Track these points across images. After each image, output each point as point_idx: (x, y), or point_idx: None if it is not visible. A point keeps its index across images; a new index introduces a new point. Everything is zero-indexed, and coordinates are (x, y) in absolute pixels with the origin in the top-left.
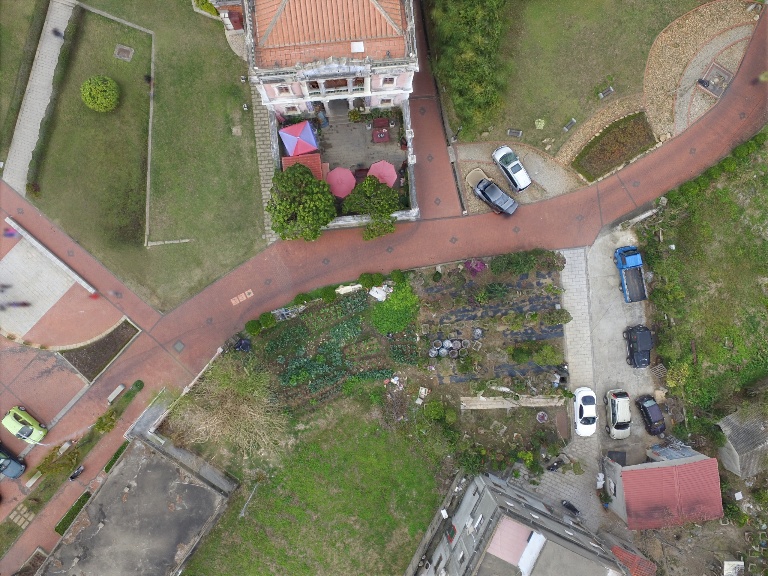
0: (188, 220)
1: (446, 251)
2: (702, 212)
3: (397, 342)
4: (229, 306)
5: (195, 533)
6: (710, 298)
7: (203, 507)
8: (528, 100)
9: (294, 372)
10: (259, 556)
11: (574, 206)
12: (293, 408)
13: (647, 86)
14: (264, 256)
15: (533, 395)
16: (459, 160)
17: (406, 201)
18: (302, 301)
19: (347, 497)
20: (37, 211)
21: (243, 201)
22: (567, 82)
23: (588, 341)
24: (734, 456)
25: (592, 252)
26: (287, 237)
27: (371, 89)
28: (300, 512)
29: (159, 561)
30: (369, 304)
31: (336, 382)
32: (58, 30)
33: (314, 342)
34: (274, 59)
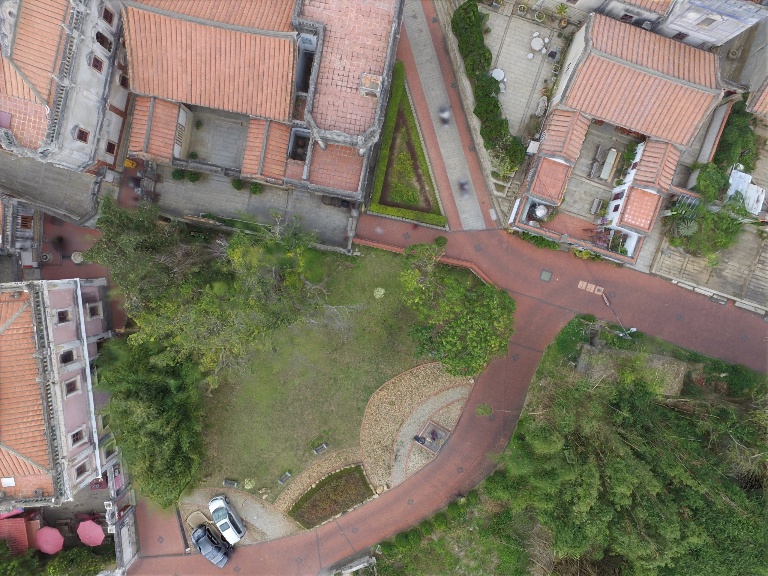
0: None
1: None
2: (416, 563)
3: None
4: None
5: None
6: None
7: None
8: (244, 451)
9: None
10: None
11: (293, 549)
12: None
13: (364, 440)
14: None
15: None
16: (180, 503)
17: None
18: None
19: None
20: None
21: None
22: (283, 435)
23: None
24: None
25: None
26: None
27: None
28: None
29: None
30: None
31: None
32: None
33: None
34: None
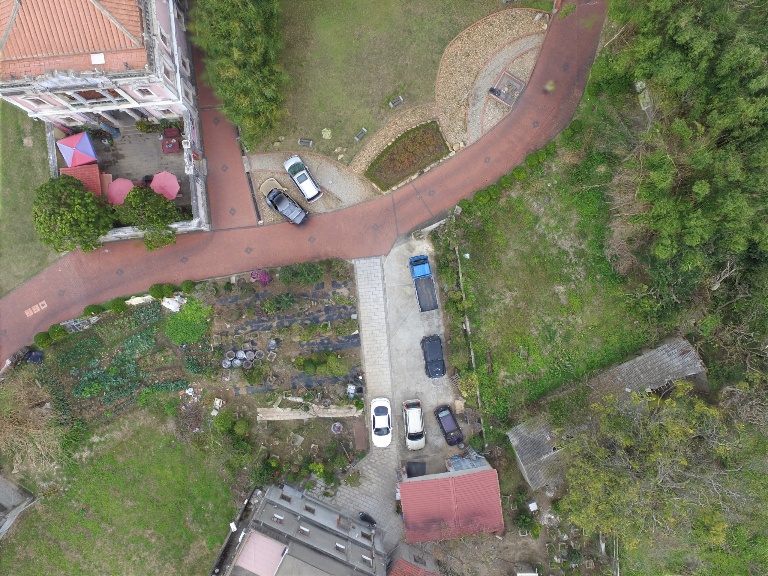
0: None
1: (241, 261)
2: (496, 221)
3: (192, 353)
4: (23, 317)
5: None
6: (506, 307)
7: None
8: (319, 110)
9: (87, 384)
10: (53, 571)
11: (369, 215)
12: (87, 420)
13: (439, 95)
14: (58, 267)
15: (326, 406)
16: (253, 170)
17: None
18: (90, 312)
19: (142, 510)
20: None
21: None
22: (358, 92)
23: (385, 351)
24: (522, 467)
25: (388, 261)
26: (58, 248)
27: (136, 100)
28: (95, 526)
29: None
30: (164, 315)
31: (131, 394)
32: None
33: (108, 353)
34: (13, 71)
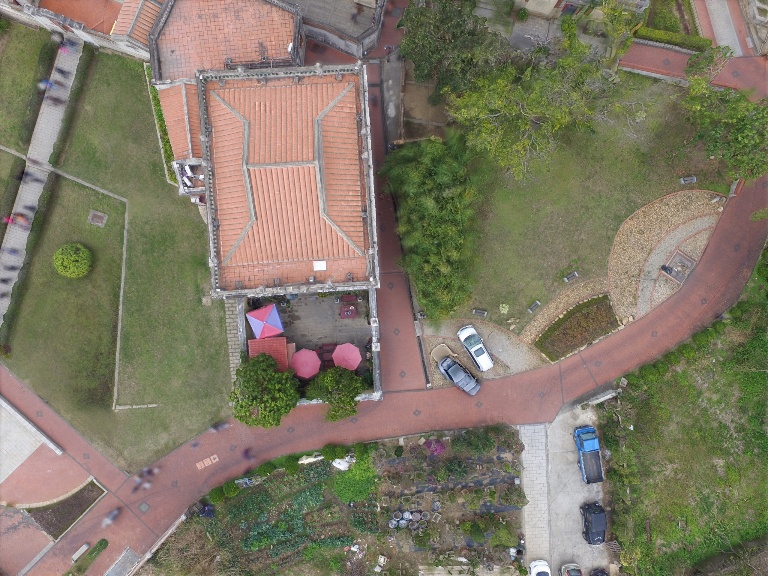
0: (156, 386)
1: (409, 423)
2: (661, 395)
3: (358, 510)
4: (194, 470)
5: None
6: (666, 478)
7: None
8: (494, 281)
9: (256, 538)
10: None
11: (536, 383)
12: (254, 572)
13: (612, 270)
14: (230, 423)
15: (489, 569)
16: (425, 335)
17: (371, 378)
18: (265, 473)
19: None
20: (7, 371)
21: (211, 369)
22: (533, 264)
23: (546, 514)
24: None
25: (552, 428)
26: None
27: None
28: None
29: None
30: (332, 473)
31: (297, 548)
32: (33, 194)
33: (277, 508)
34: (237, 275)
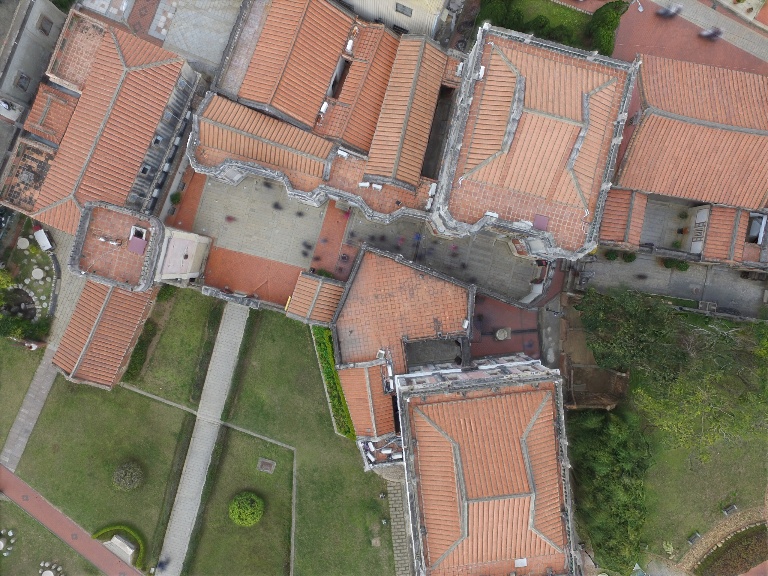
0: None
1: None
2: None
3: None
4: None
5: None
6: None
7: None
8: (654, 514)
9: None
10: None
11: None
12: None
13: None
14: None
15: None
16: (586, 566)
17: None
18: None
19: None
20: None
21: None
22: (692, 497)
23: None
24: None
25: None
26: None
27: None
28: None
29: None
30: None
31: None
32: (204, 446)
33: None
34: (443, 575)
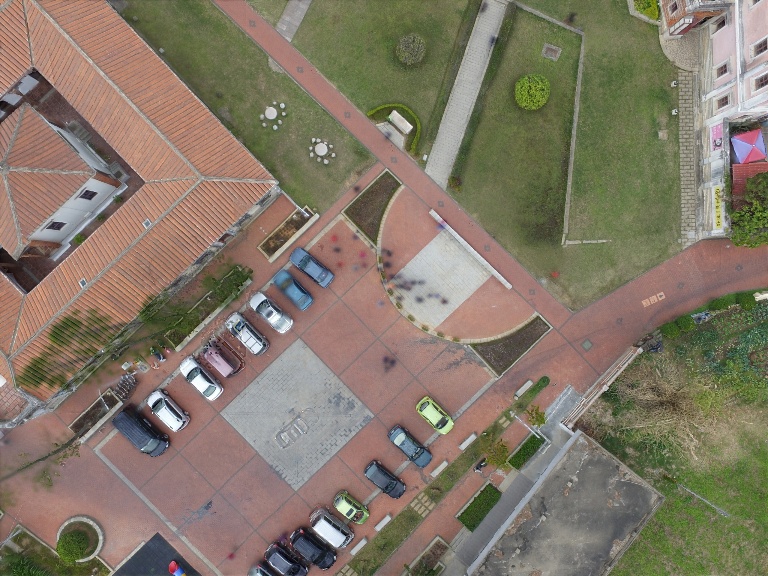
0: (608, 221)
1: None
2: None
3: None
4: (640, 308)
5: (631, 530)
6: None
7: (639, 505)
8: None
9: (703, 376)
10: (656, 554)
11: None
12: None
13: None
14: (678, 260)
15: None
16: None
17: None
18: (726, 306)
19: (745, 501)
20: (457, 205)
21: (663, 205)
22: None
23: None
24: None
25: None
26: (746, 244)
27: None
28: (699, 513)
29: (595, 556)
30: None
31: (741, 387)
32: (489, 26)
33: (723, 347)
34: None
